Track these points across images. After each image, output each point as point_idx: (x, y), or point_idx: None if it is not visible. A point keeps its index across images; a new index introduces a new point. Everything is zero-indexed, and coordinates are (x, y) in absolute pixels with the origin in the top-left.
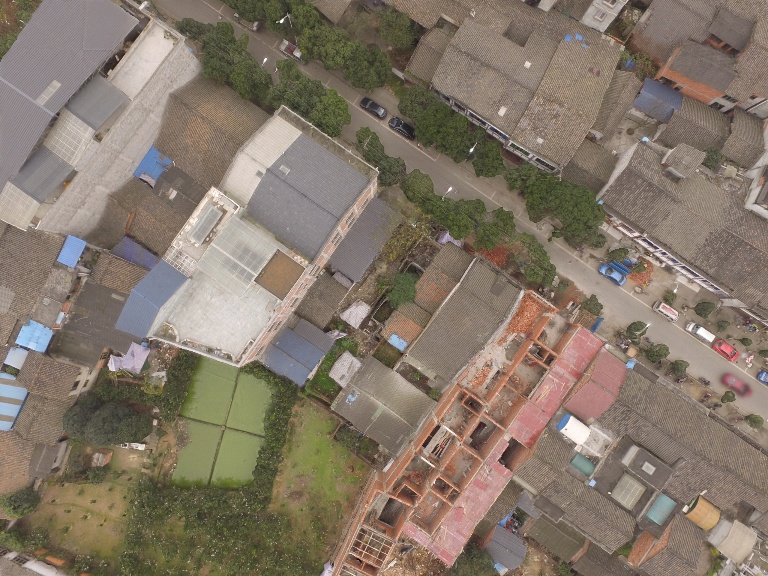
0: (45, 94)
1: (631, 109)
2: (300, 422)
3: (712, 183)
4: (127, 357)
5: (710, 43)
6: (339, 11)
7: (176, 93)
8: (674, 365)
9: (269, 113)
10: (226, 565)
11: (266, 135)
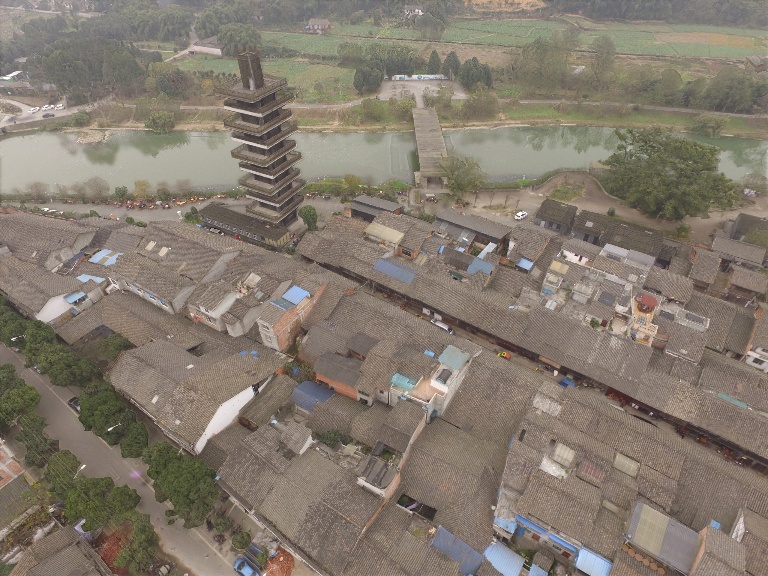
0: None
1: (295, 405)
2: None
3: (330, 460)
4: None
5: (356, 356)
6: (77, 337)
7: None
8: None
9: None
10: None
11: None
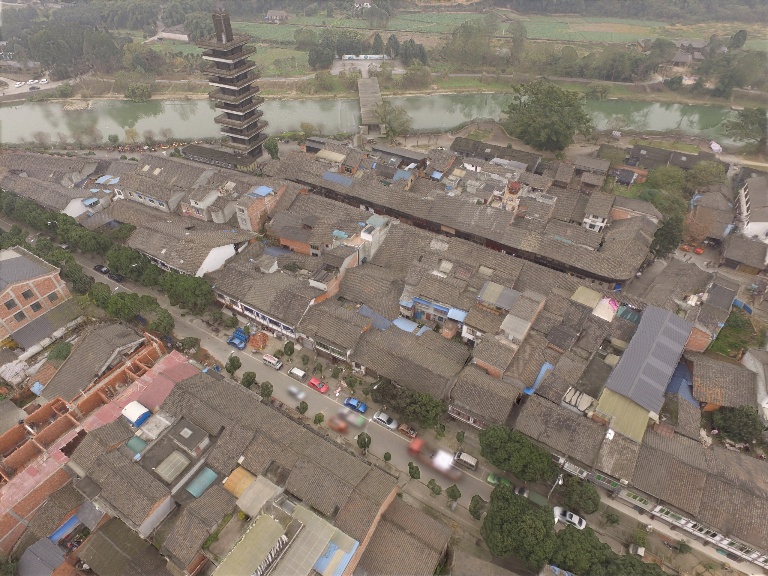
0: None
1: None
2: None
3: (290, 276)
4: None
5: None
6: (96, 226)
7: None
8: (261, 387)
9: None
10: None
11: None
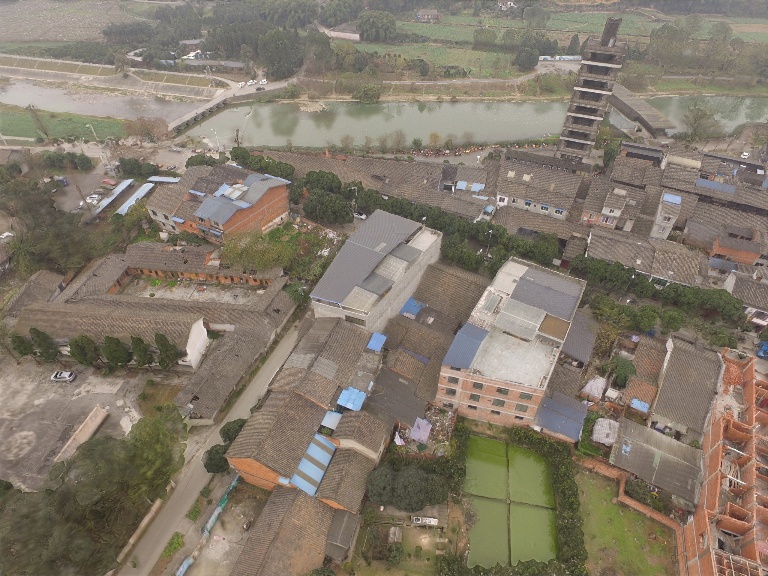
0: (378, 247)
1: (708, 271)
2: (580, 490)
3: None
4: (414, 429)
5: None
6: None
7: (431, 265)
8: None
9: (486, 277)
10: None
11: None
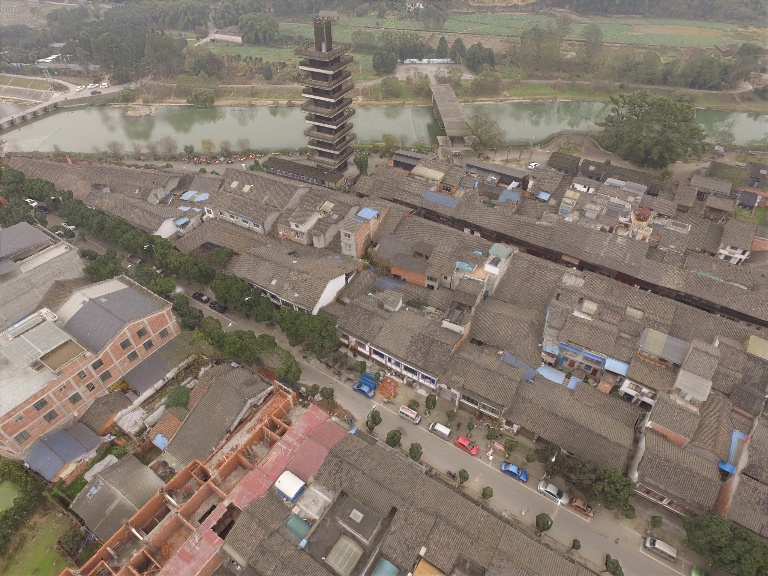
0: None
1: (376, 292)
2: (34, 535)
3: (418, 315)
4: None
5: None
6: (190, 249)
7: (61, 281)
8: None
9: None
10: None
11: (102, 286)
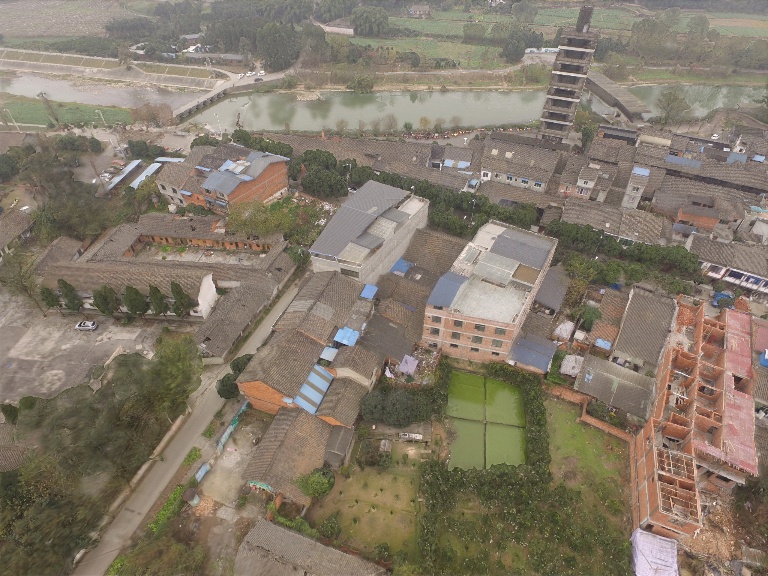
0: (370, 210)
1: (672, 235)
2: (548, 413)
3: None
4: (403, 364)
5: None
6: None
7: None
8: None
9: (469, 240)
10: (530, 543)
11: (489, 227)
